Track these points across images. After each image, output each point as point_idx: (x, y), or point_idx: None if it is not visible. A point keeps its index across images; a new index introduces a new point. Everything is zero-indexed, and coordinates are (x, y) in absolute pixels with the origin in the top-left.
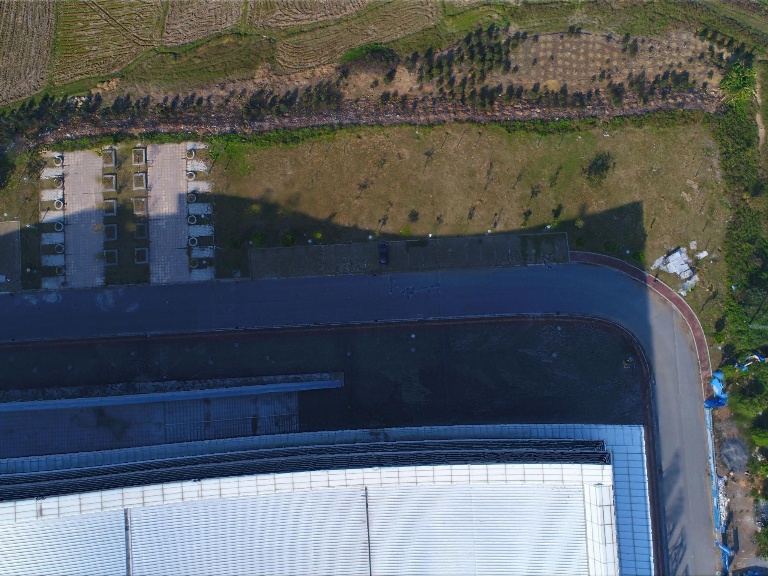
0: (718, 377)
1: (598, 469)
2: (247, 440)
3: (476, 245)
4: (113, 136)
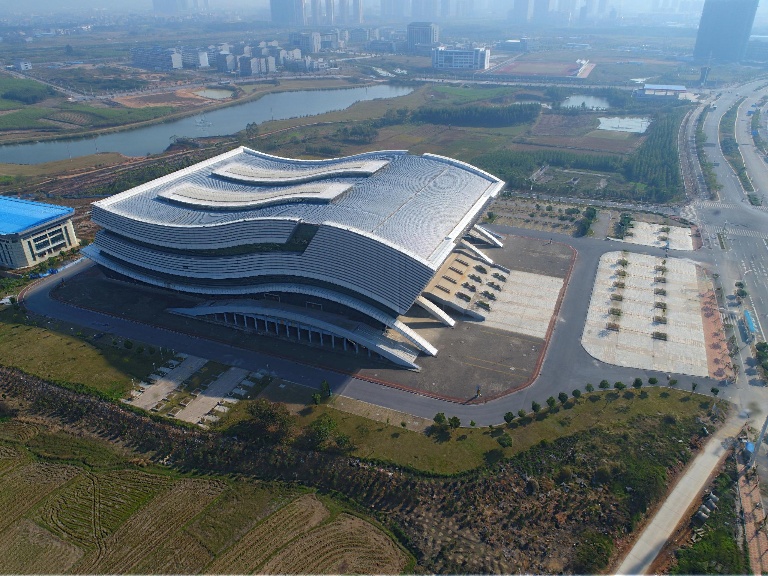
0: (42, 275)
1: (95, 204)
2: (214, 289)
3: None
4: (161, 419)
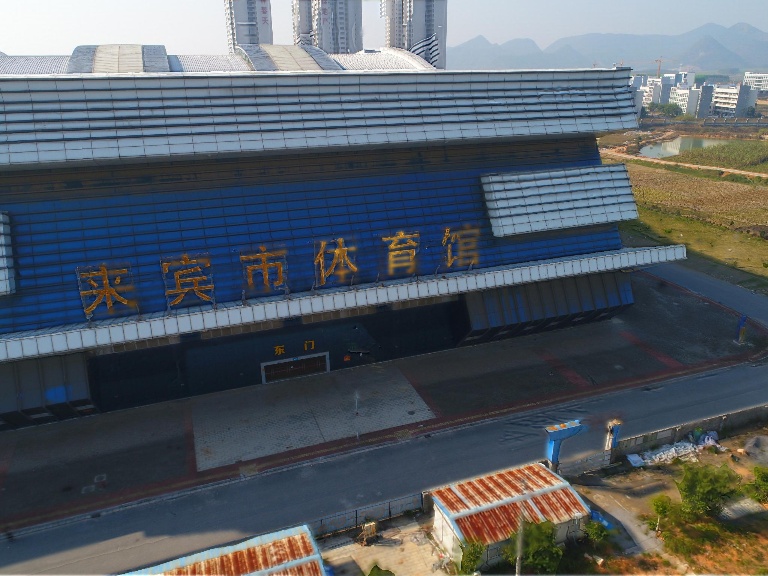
0: None
1: None
2: None
3: (709, 265)
4: None
